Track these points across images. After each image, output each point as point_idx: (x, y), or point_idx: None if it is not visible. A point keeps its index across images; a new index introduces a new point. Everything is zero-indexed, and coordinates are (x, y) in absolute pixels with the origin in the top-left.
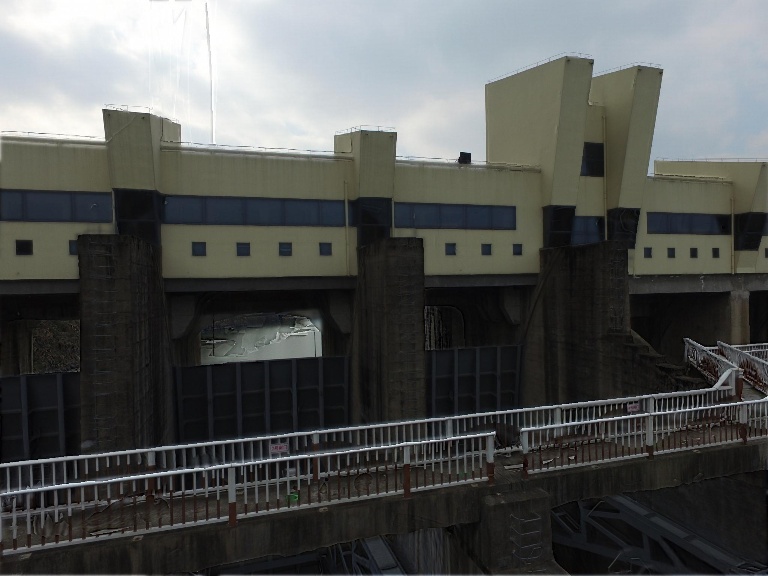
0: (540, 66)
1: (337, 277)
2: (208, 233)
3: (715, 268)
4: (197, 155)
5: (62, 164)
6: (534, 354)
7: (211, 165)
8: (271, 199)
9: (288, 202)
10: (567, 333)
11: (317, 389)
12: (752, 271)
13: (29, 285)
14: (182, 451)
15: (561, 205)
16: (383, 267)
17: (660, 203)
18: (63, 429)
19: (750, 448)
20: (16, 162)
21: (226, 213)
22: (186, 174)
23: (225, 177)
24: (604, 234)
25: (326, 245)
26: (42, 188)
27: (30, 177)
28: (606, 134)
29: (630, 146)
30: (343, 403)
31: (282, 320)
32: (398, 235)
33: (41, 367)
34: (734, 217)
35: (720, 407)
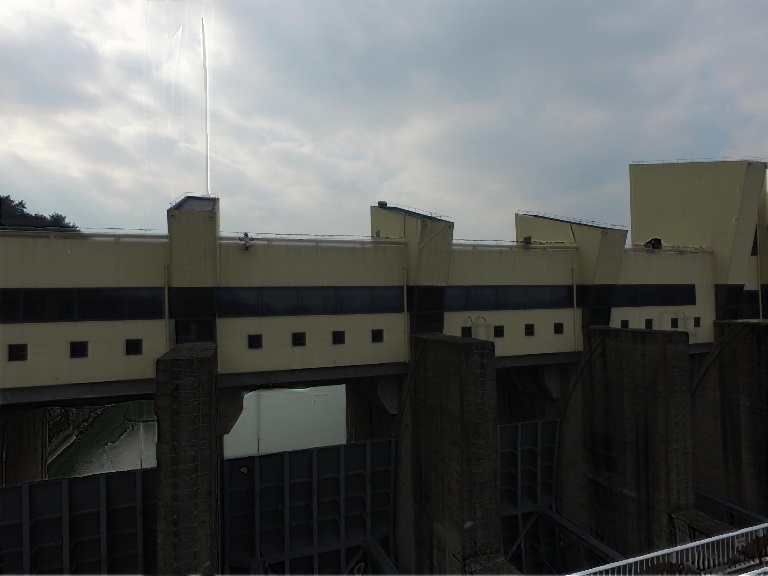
0: (712, 162)
1: (567, 353)
2: (473, 318)
3: None
4: (465, 250)
5: (366, 262)
6: (706, 413)
7: (475, 258)
8: (518, 286)
9: (530, 288)
10: (754, 399)
11: (534, 450)
12: None
13: (339, 371)
14: (689, 550)
15: (734, 284)
16: (657, 357)
17: None
18: (344, 496)
19: None
20: (333, 262)
21: (484, 299)
22: (456, 267)
23: (485, 268)
24: (759, 305)
25: (559, 325)
26: (351, 284)
27: (342, 275)
28: (759, 218)
29: None
30: (552, 461)
31: None
32: (611, 313)
33: None
34: None
35: None
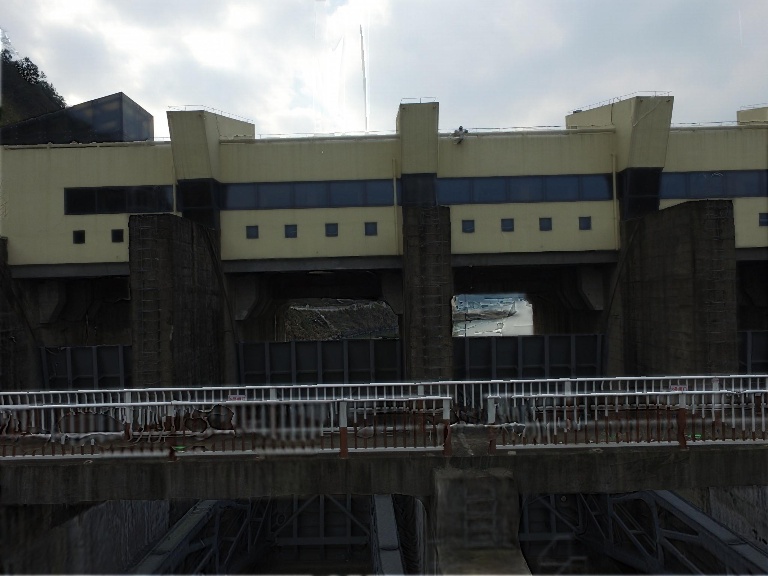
0: None
1: None
2: None
3: None
4: (682, 134)
5: (572, 151)
6: None
7: (694, 142)
8: (750, 171)
9: (766, 173)
10: None
11: None
12: None
13: (546, 257)
14: None
15: None
16: None
17: None
18: None
19: None
20: (538, 152)
21: (705, 187)
22: (672, 152)
23: (707, 153)
24: None
25: None
26: (557, 173)
27: (548, 164)
28: None
29: None
30: None
31: None
32: None
33: None
34: None
35: None
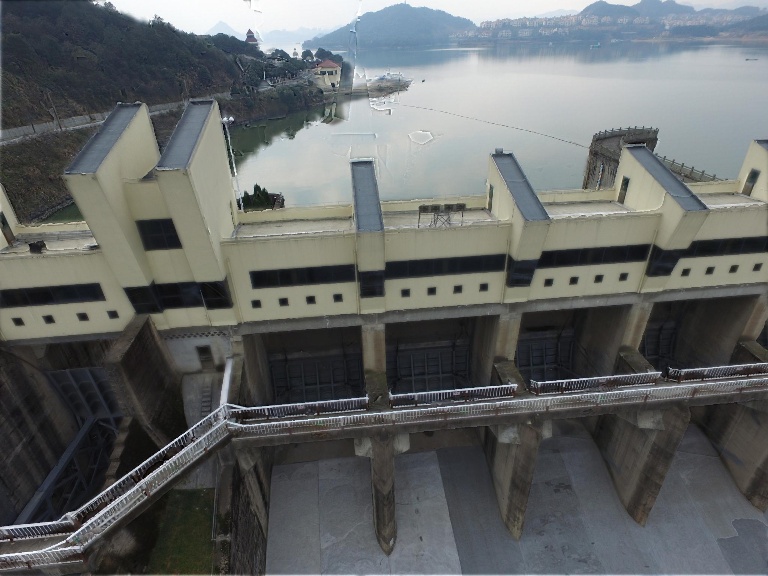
0: None
1: None
2: None
3: (338, 310)
4: None
5: None
6: None
7: None
8: None
9: None
10: None
11: None
12: (381, 311)
13: None
14: None
15: (133, 287)
16: None
17: (265, 262)
18: None
19: (33, 570)
20: None
21: None
22: None
23: None
24: (201, 296)
25: None
26: None
27: None
28: None
29: (184, 237)
30: None
31: (309, 107)
32: None
33: (34, 205)
34: (357, 268)
35: (0, 557)
